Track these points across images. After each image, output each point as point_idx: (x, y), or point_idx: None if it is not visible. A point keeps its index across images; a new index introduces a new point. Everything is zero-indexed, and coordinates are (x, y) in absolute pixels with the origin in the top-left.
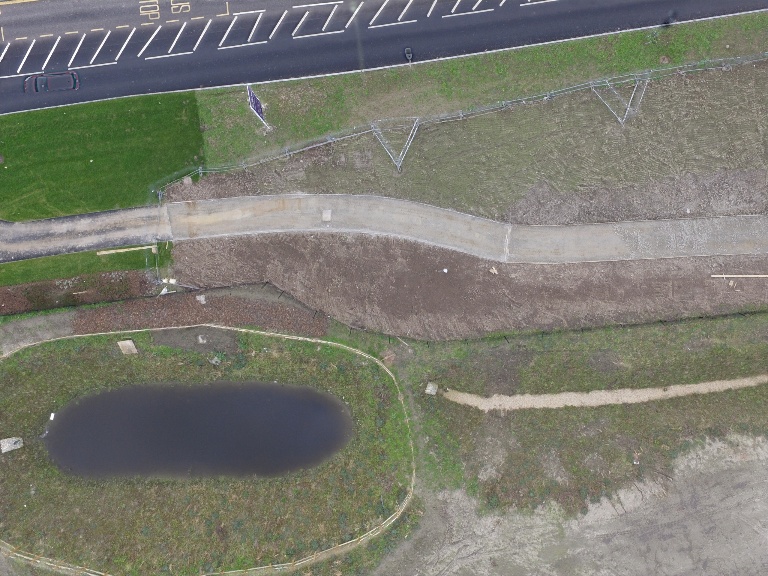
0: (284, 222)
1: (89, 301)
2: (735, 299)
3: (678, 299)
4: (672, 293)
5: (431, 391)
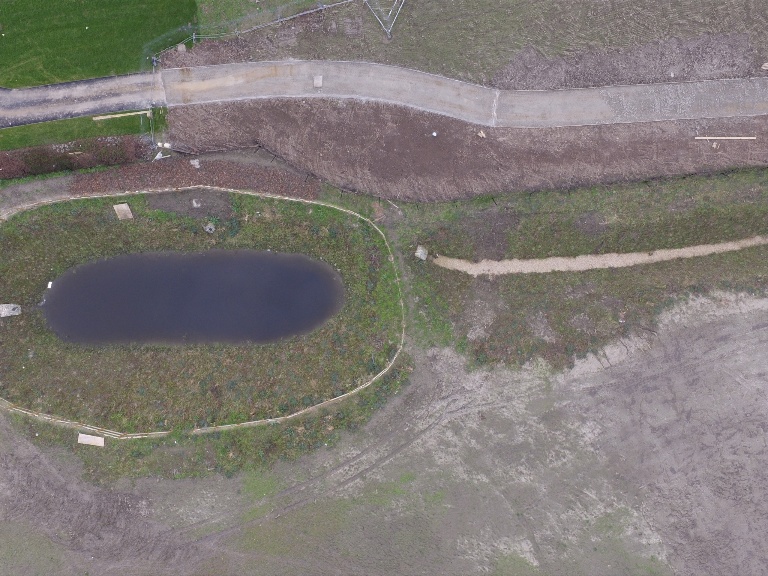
0: (276, 88)
1: (85, 165)
2: (718, 160)
3: (662, 161)
4: (656, 155)
5: (421, 255)
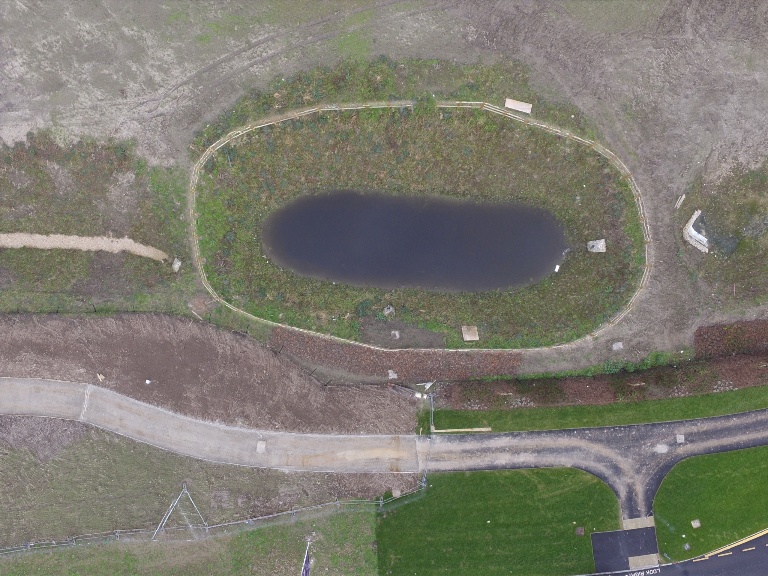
0: (304, 443)
1: (503, 383)
2: None
3: None
4: None
5: (177, 263)
